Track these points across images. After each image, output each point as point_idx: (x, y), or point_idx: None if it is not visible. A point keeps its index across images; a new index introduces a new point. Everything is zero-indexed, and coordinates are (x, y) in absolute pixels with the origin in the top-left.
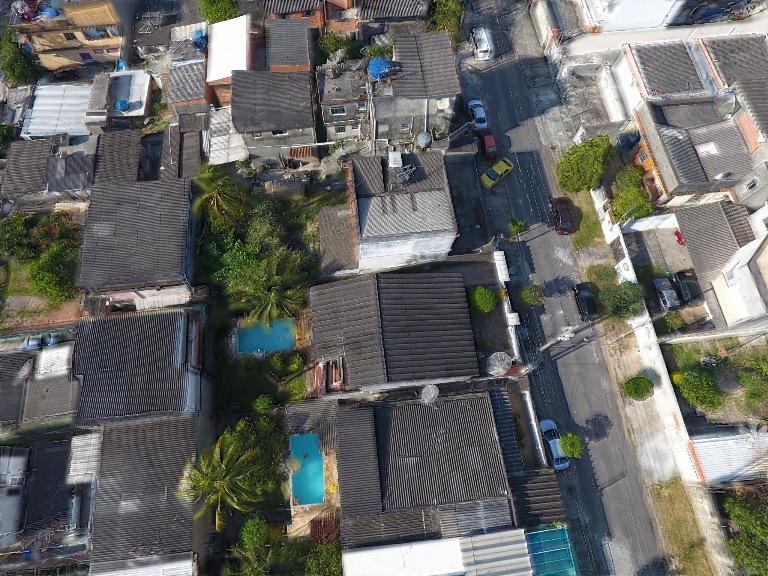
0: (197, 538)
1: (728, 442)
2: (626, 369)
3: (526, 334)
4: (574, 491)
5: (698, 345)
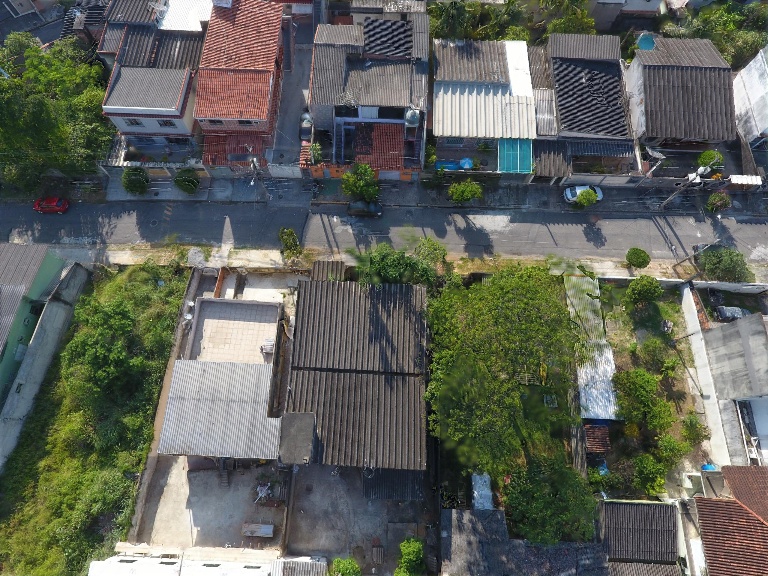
0: (518, 2)
1: (599, 304)
2: (648, 272)
3: (675, 201)
4: (546, 206)
5: (683, 327)
